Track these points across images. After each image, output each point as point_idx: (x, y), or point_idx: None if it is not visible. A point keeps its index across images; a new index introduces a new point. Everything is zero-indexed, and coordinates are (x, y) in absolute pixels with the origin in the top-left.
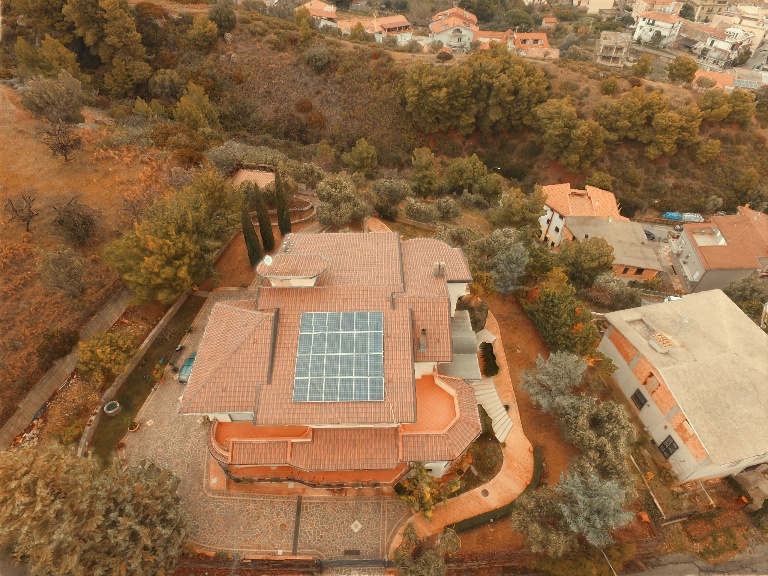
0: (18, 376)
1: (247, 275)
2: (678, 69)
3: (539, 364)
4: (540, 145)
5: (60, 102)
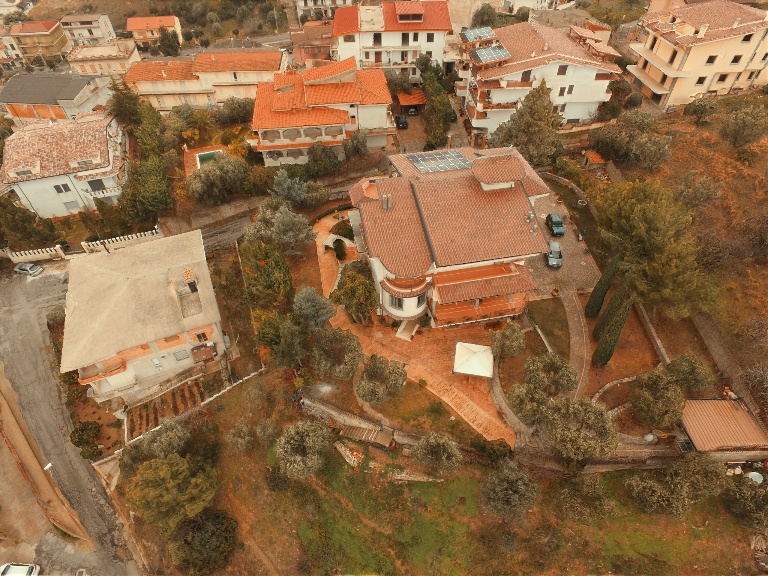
0: None
1: None
2: None
3: None
4: None
5: None
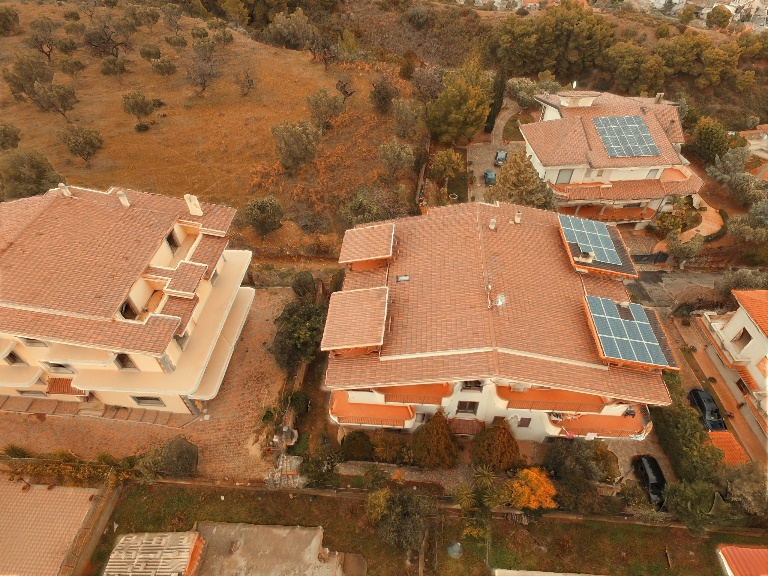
0: (404, 173)
1: (484, 137)
2: (716, 17)
3: (717, 160)
4: (609, 82)
5: (300, 32)
